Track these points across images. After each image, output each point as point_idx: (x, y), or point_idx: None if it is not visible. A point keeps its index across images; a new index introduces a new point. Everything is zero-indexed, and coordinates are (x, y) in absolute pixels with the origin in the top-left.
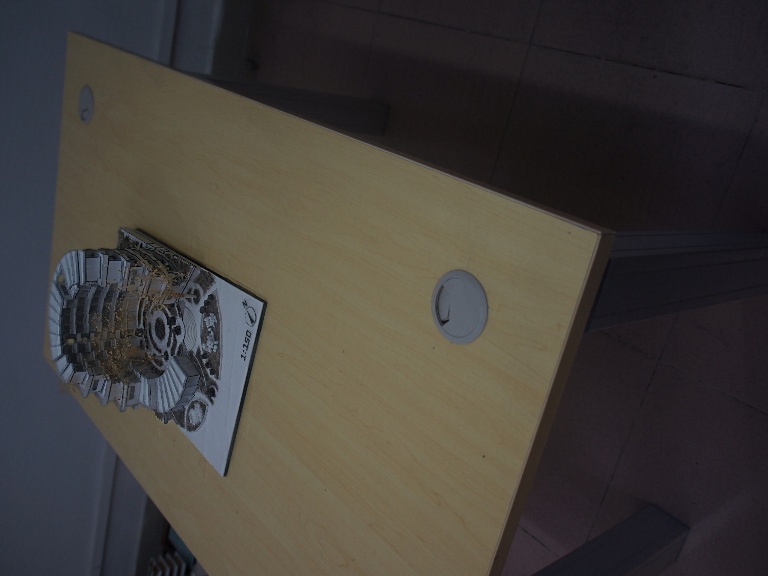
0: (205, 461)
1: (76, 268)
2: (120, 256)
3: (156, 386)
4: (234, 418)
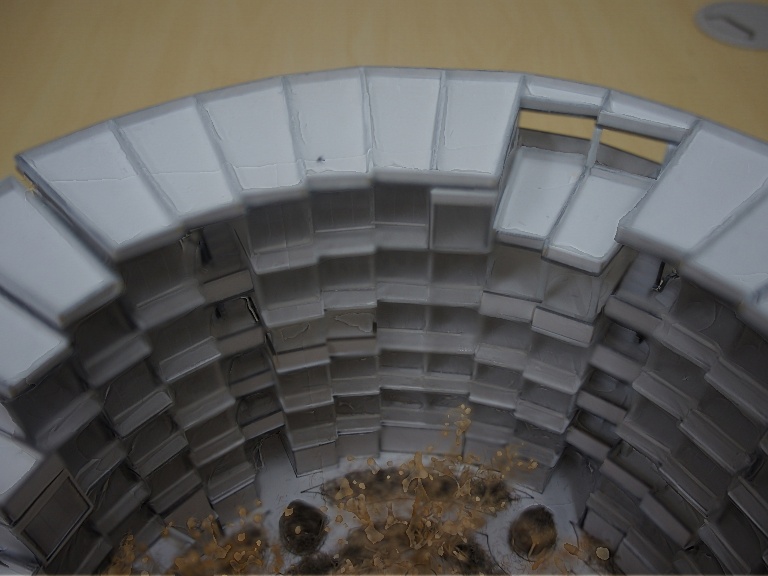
0: None
1: None
2: None
3: None
4: None
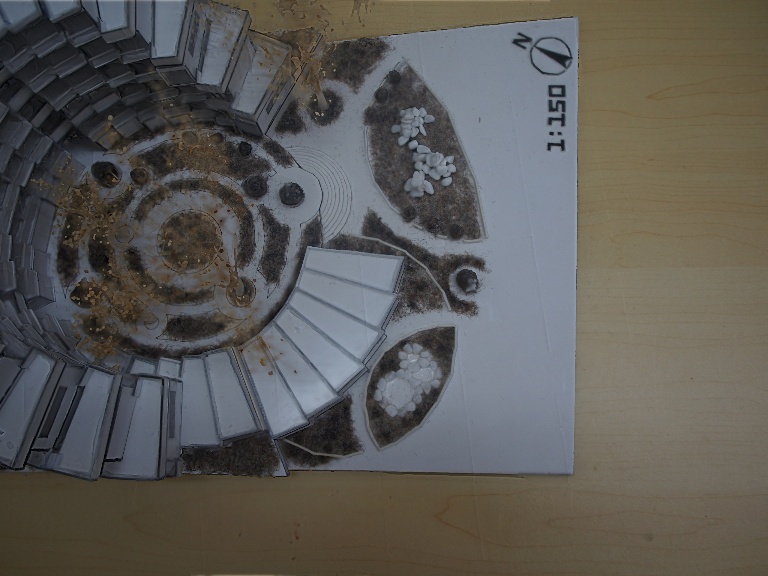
0: (467, 495)
1: None
2: None
3: (247, 368)
4: (571, 295)
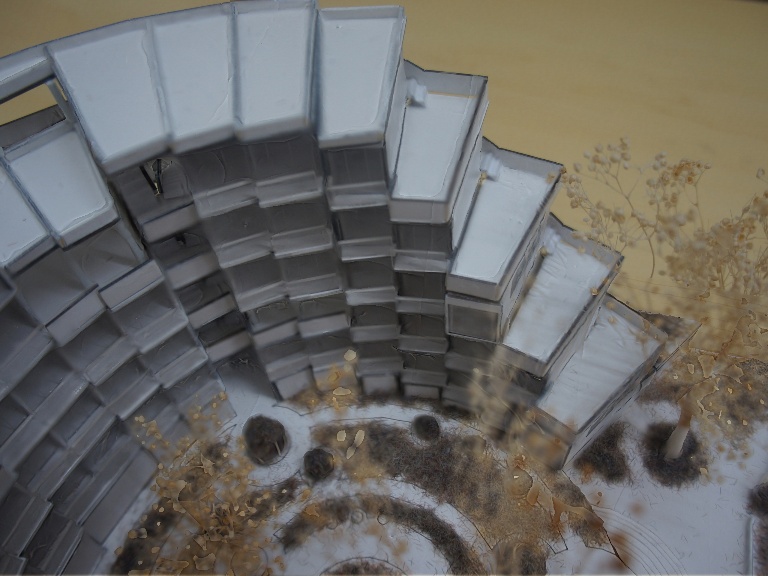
0: None
1: (307, 57)
2: None
3: None
4: None
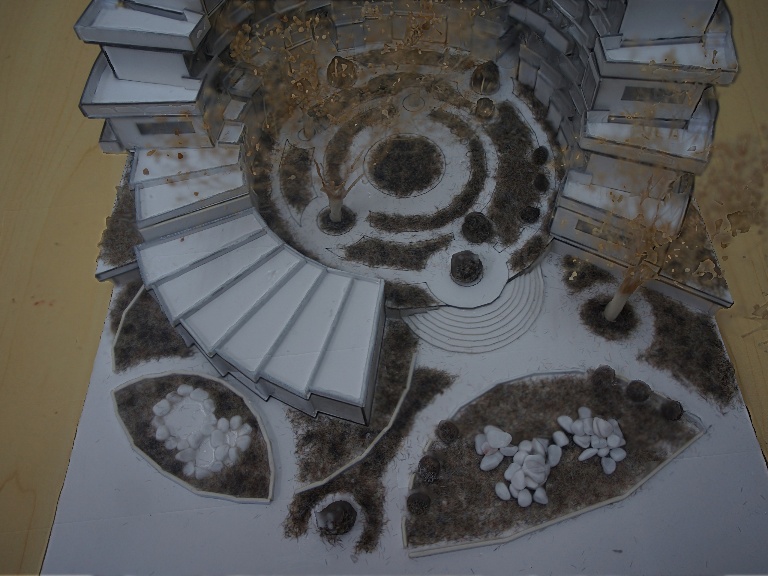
0: (31, 517)
1: None
2: (715, 24)
3: (227, 218)
4: None
